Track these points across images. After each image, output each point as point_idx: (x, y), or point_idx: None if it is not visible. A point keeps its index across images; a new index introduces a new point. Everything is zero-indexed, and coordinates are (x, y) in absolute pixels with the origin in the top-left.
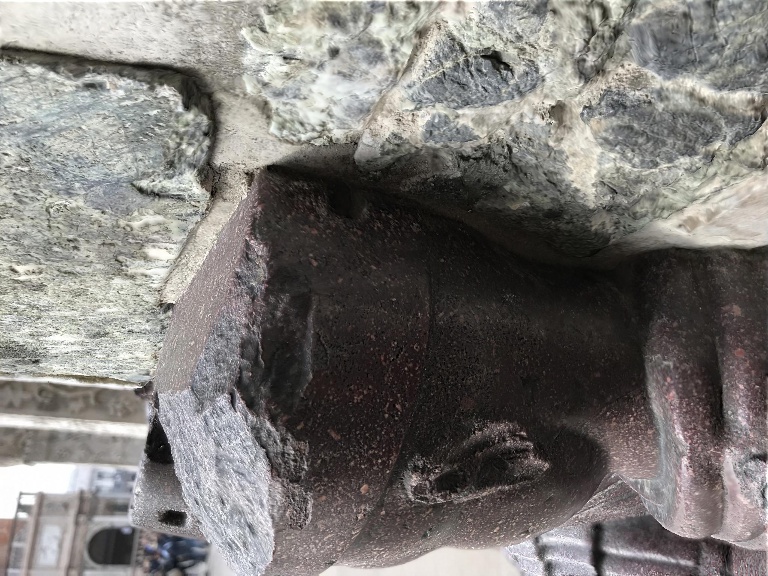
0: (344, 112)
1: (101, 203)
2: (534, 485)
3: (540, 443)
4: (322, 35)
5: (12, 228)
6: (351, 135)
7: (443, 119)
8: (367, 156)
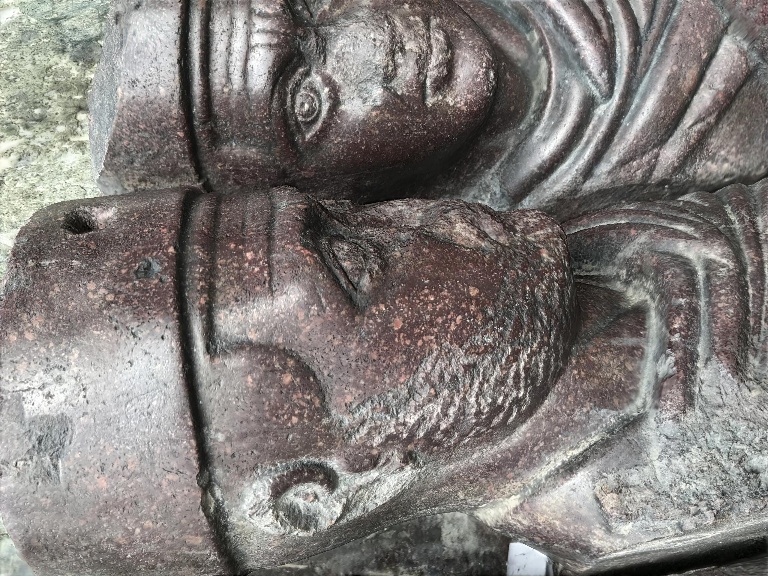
0: None
1: (79, 57)
2: None
3: None
4: None
5: (18, 90)
6: None
7: None
8: None
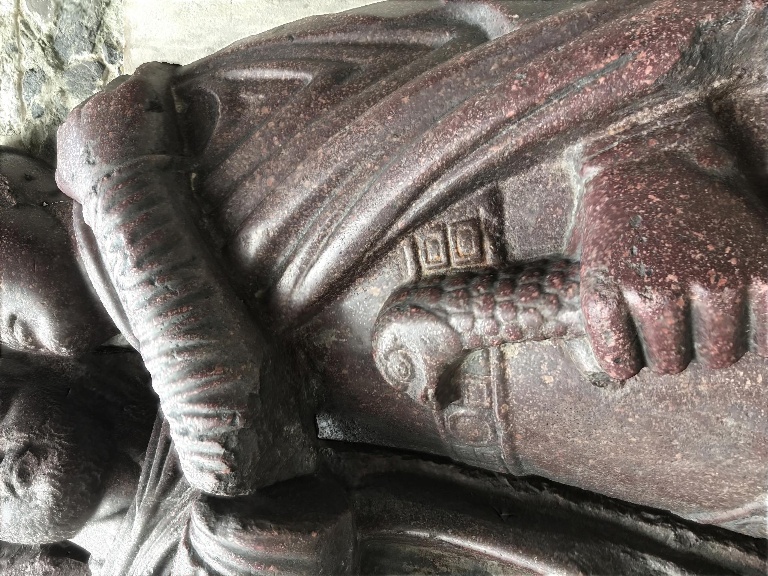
0: (13, 114)
1: None
2: (4, 211)
3: (17, 195)
4: None
5: None
6: (20, 129)
7: (33, 104)
8: (23, 135)
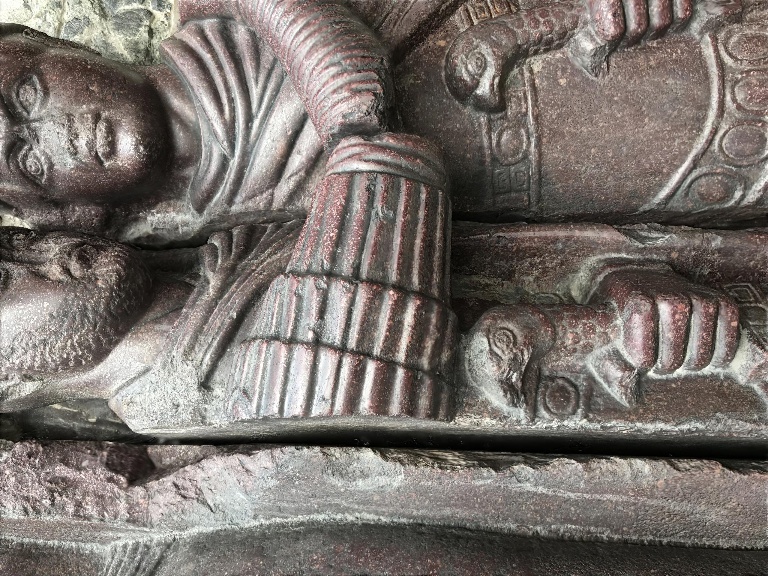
0: None
1: None
2: None
3: None
4: (36, 23)
5: None
6: None
7: None
8: None
